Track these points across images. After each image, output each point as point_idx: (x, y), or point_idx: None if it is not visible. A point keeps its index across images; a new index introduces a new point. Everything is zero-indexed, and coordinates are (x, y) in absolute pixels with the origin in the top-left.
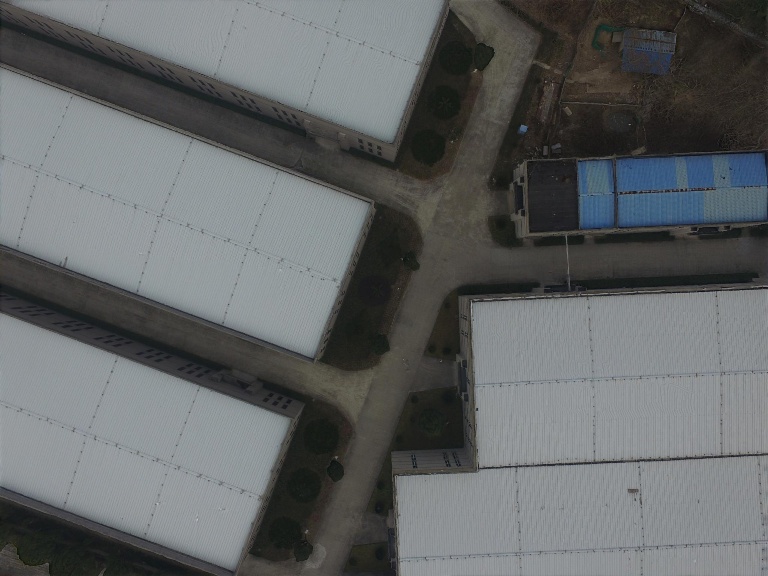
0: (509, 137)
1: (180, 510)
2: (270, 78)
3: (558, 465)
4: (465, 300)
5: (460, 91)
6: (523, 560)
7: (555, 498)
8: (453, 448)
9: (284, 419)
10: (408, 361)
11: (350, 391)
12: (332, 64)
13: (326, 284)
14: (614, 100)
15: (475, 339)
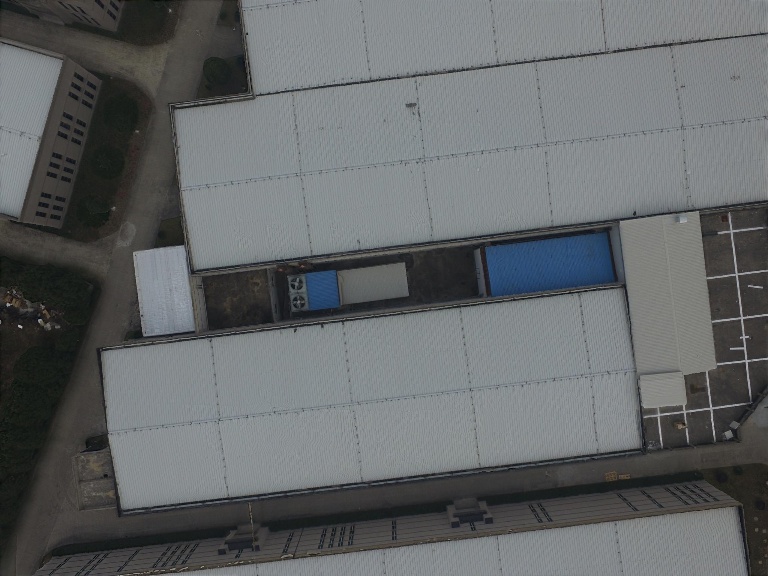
0: None
1: None
2: None
3: (334, 86)
4: None
5: None
6: (305, 181)
7: (333, 118)
8: None
9: (60, 63)
10: (202, 32)
11: (147, 66)
12: None
13: None
14: None
15: None
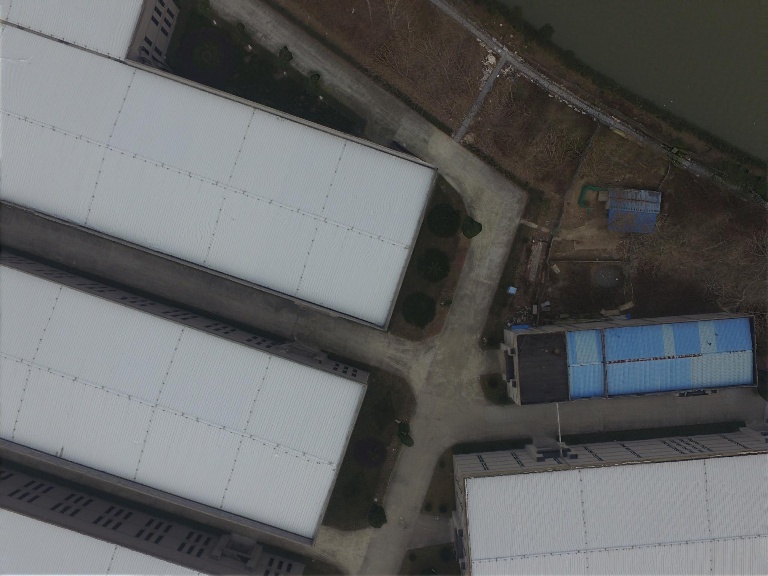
0: (499, 297)
1: None
2: (260, 268)
3: None
4: None
5: (449, 253)
6: None
7: None
8: None
9: None
10: (405, 519)
11: (349, 551)
12: (321, 253)
13: (322, 468)
14: (601, 256)
15: (470, 515)
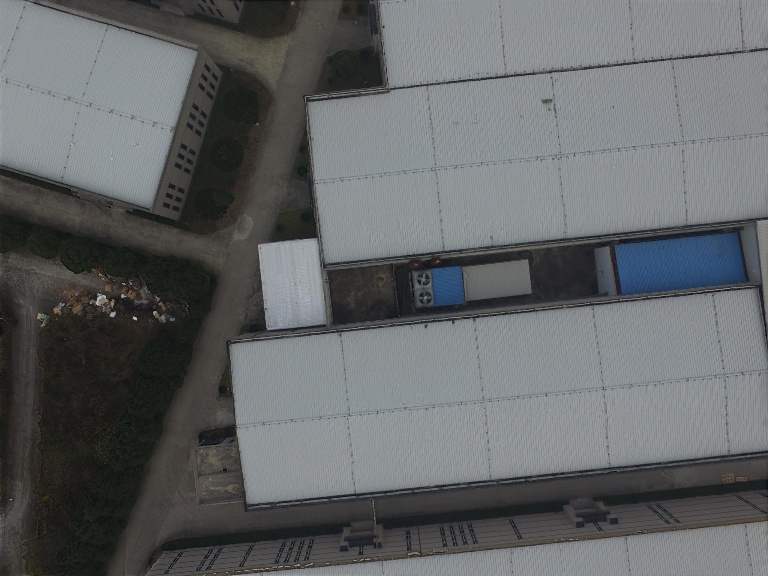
0: None
1: (95, 149)
2: None
3: (469, 81)
4: None
5: None
6: (439, 175)
7: (468, 113)
8: None
9: (193, 53)
10: (323, 25)
11: (267, 59)
12: None
13: None
14: None
15: None
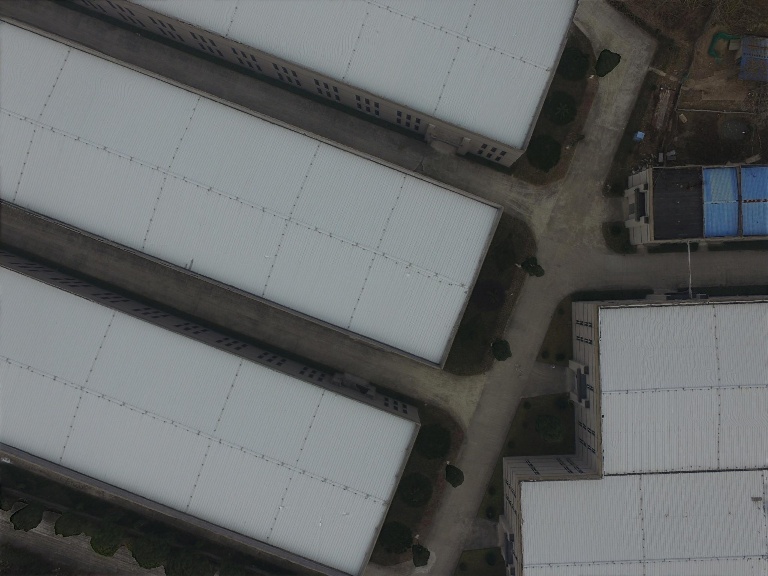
0: (625, 143)
1: (303, 514)
2: (402, 82)
3: (682, 473)
4: (589, 307)
5: (576, 97)
6: (647, 567)
7: (679, 506)
8: (565, 454)
9: (408, 424)
10: (520, 367)
11: (462, 396)
12: (464, 69)
13: (454, 289)
14: (729, 108)
15: (601, 346)
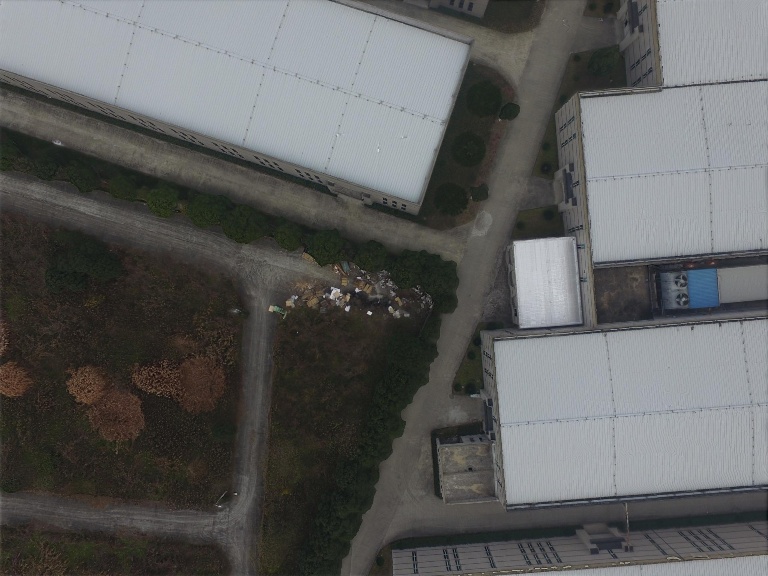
0: None
1: (361, 141)
2: None
3: (742, 82)
4: None
5: None
6: (712, 176)
7: (741, 114)
8: None
9: (462, 46)
10: (568, 22)
11: (510, 54)
12: None
13: None
14: None
15: None
